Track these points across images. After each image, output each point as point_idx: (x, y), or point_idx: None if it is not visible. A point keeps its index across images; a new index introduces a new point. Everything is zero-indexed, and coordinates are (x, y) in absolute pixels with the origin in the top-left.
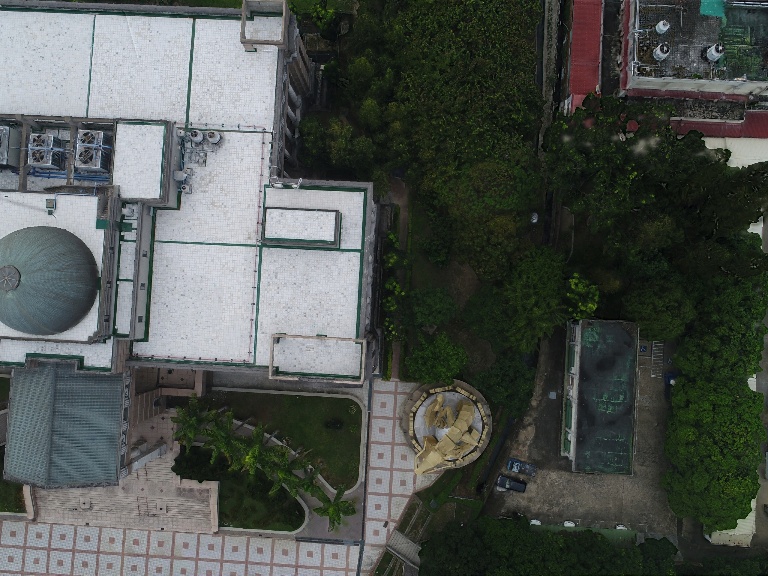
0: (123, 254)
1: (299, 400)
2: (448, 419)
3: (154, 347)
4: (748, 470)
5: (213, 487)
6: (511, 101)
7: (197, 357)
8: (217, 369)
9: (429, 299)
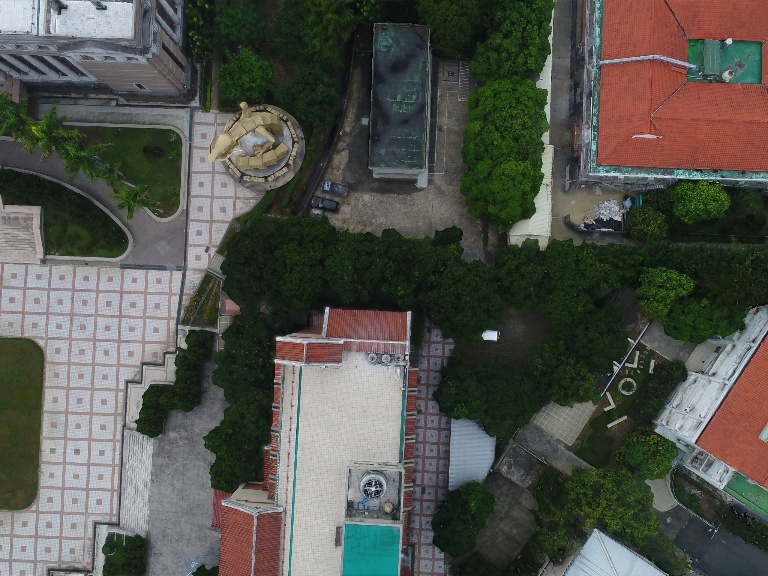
0: None
1: (121, 132)
2: (245, 116)
3: None
4: (528, 154)
5: (35, 212)
6: None
7: None
8: None
9: None
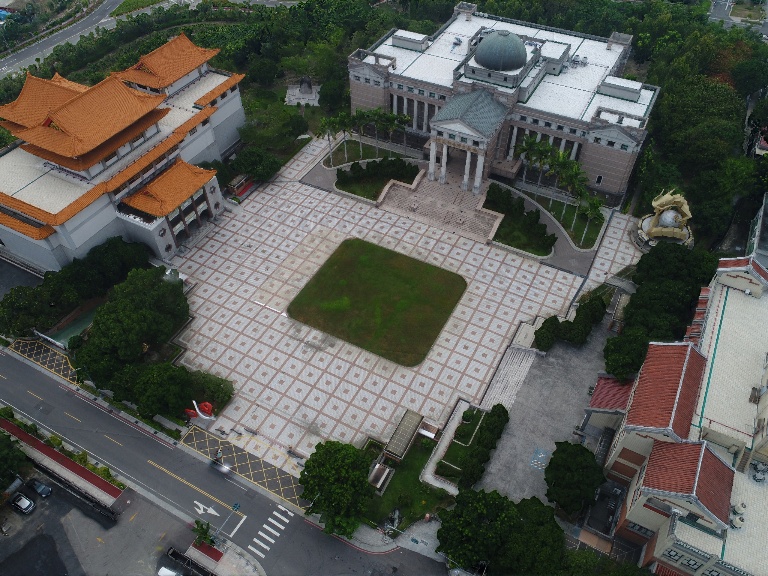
0: (532, 71)
1: None
2: None
3: (528, 106)
4: None
5: (501, 216)
6: None
7: None
8: (561, 115)
9: None
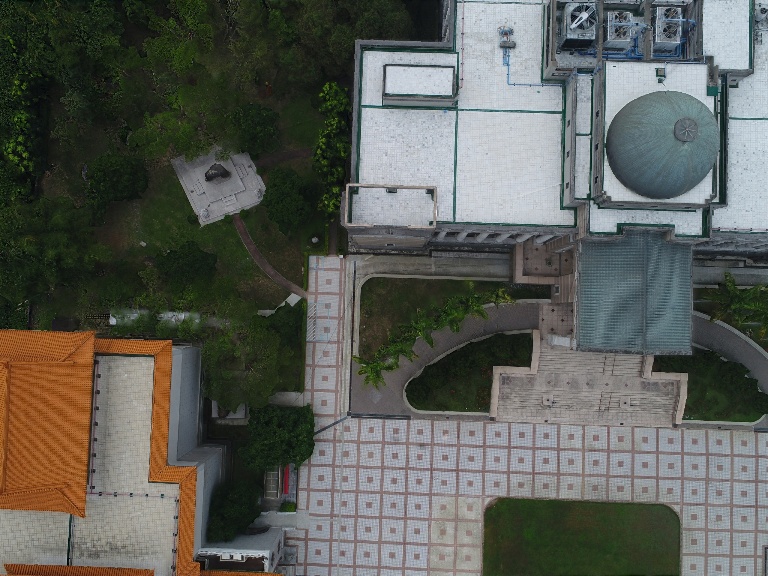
0: None
1: None
2: None
3: (720, 220)
4: None
5: (683, 379)
6: None
7: (763, 228)
8: None
9: None
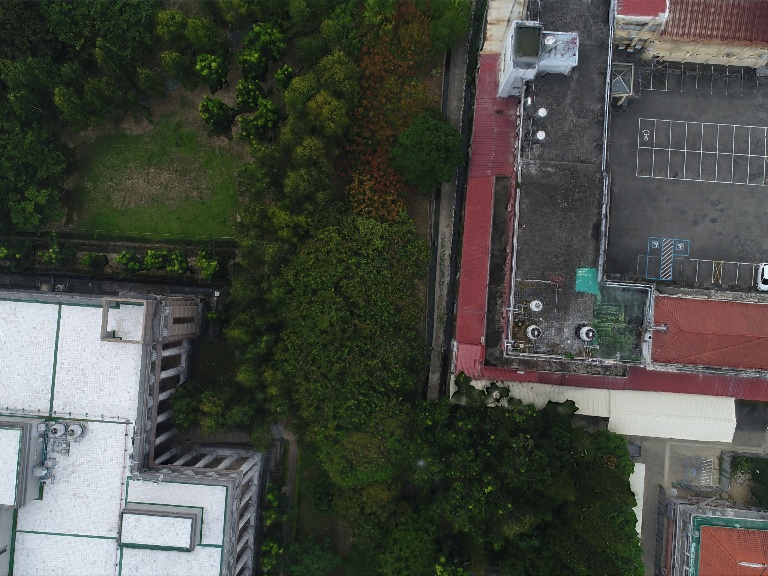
0: None
1: None
2: None
3: None
4: None
5: None
6: (388, 369)
7: None
8: None
9: (306, 559)
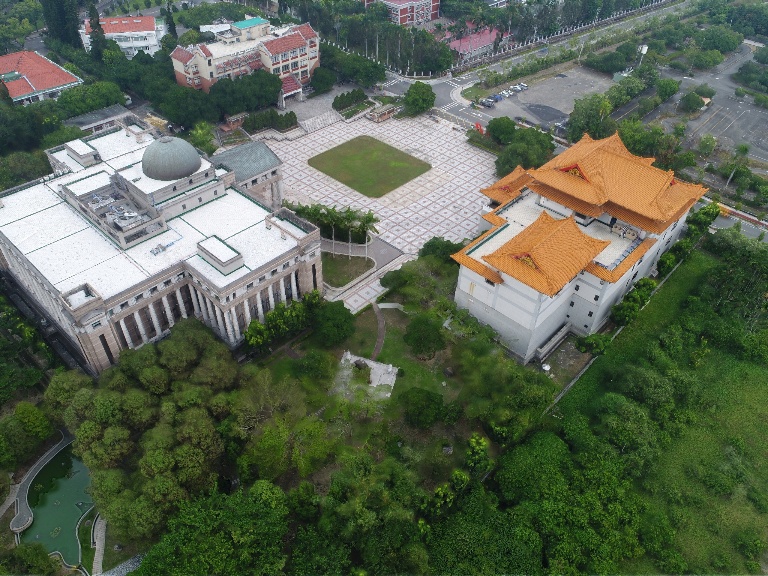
0: None
1: None
2: None
3: None
4: None
5: None
6: None
7: None
8: None
9: None
